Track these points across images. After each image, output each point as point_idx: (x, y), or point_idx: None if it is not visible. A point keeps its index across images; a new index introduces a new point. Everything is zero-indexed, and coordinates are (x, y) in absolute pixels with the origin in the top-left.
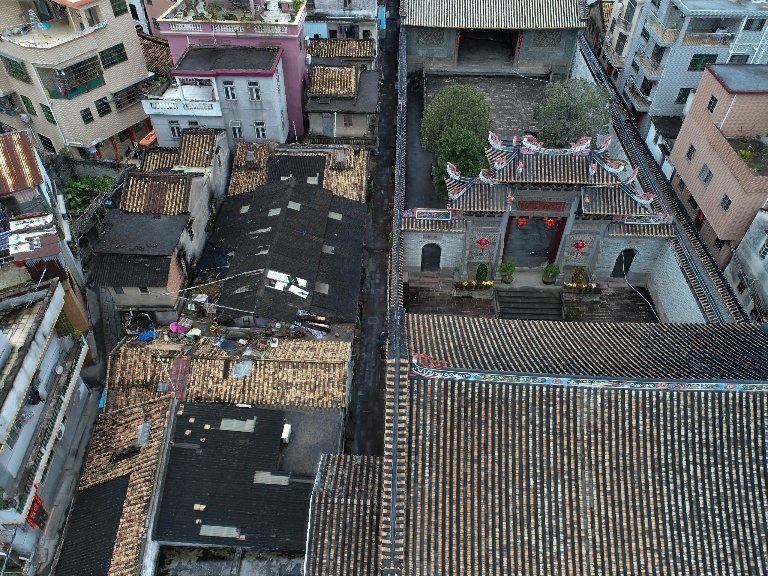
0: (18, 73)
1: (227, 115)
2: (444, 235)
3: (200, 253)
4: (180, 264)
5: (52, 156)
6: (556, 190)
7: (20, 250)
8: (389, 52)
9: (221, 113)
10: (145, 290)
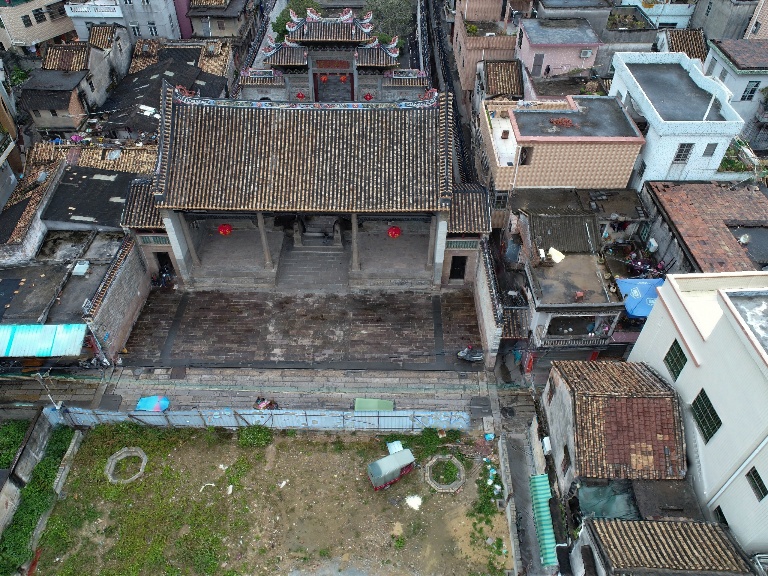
0: None
1: (127, 17)
2: (272, 90)
3: None
4: (81, 102)
5: (2, 51)
6: (339, 51)
7: None
8: None
9: (122, 15)
10: (55, 114)
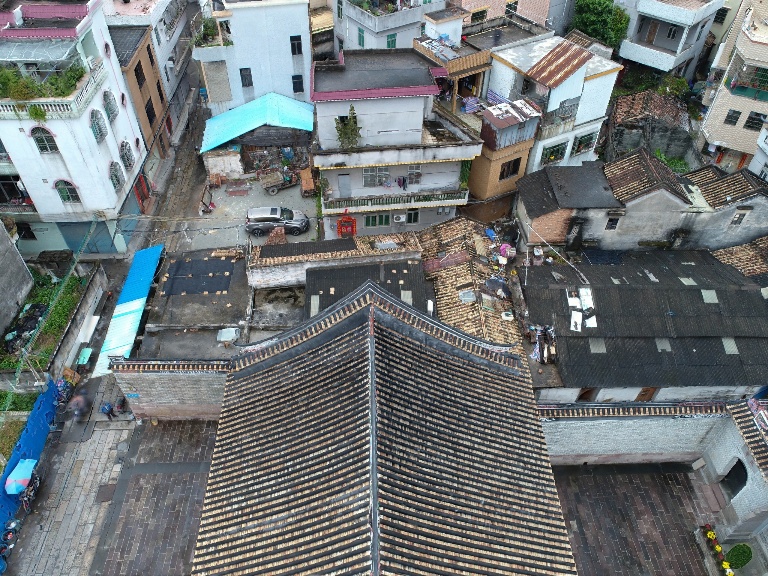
0: (731, 53)
1: None
2: None
3: (611, 249)
4: (570, 227)
5: (679, 127)
6: None
7: (493, 111)
8: None
9: None
10: None
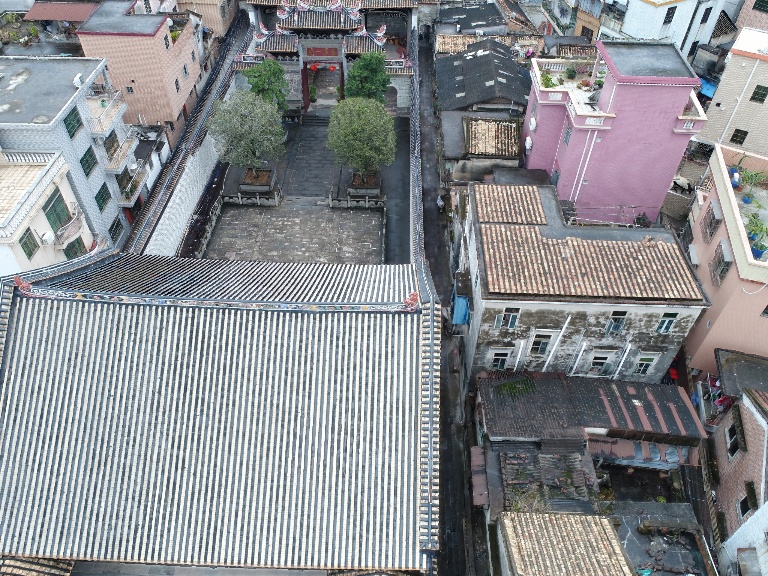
0: None
1: None
2: None
3: None
4: None
5: None
6: None
7: None
8: (442, 420)
9: None
10: None
